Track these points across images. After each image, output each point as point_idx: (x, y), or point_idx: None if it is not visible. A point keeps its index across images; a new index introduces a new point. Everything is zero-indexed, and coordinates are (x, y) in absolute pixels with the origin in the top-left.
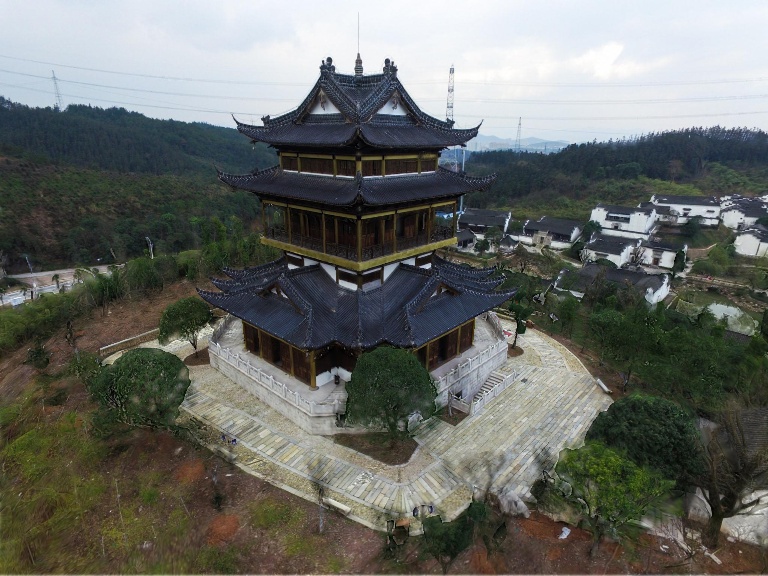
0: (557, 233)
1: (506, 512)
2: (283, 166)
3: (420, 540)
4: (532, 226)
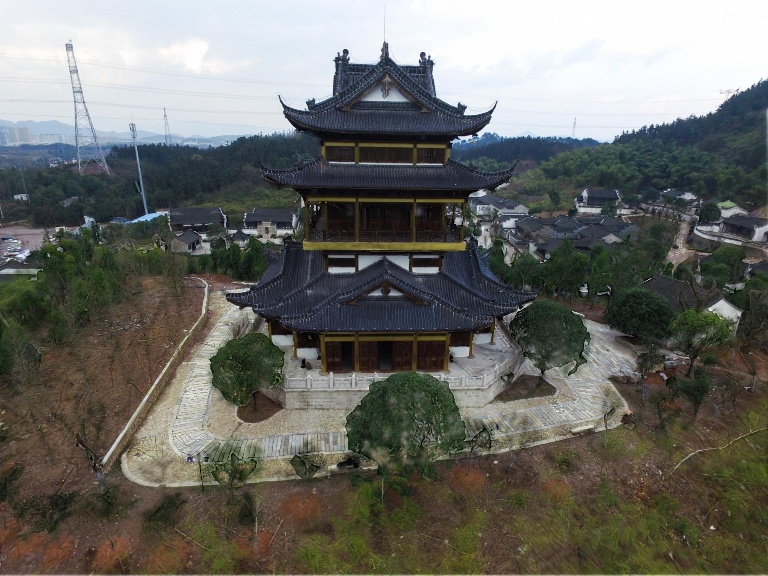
0: (278, 222)
1: (638, 381)
2: (327, 158)
3: (635, 418)
4: (252, 218)
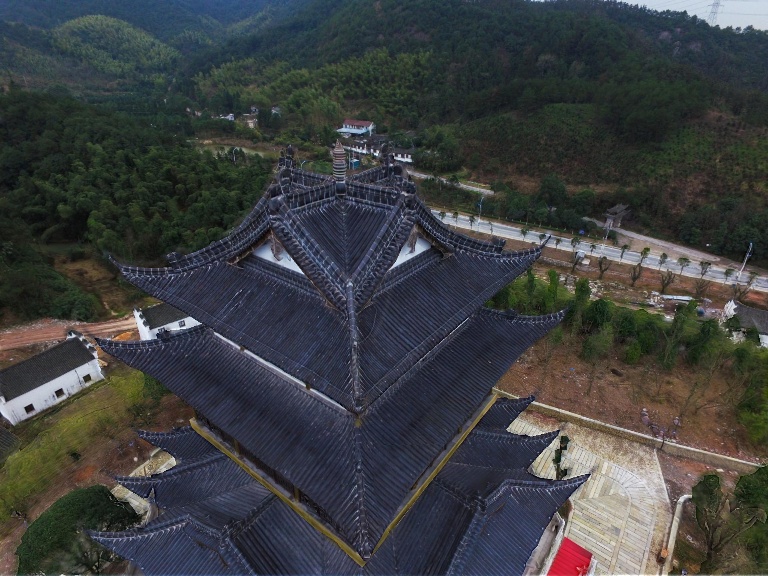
0: None
1: None
2: None
3: None
4: None
